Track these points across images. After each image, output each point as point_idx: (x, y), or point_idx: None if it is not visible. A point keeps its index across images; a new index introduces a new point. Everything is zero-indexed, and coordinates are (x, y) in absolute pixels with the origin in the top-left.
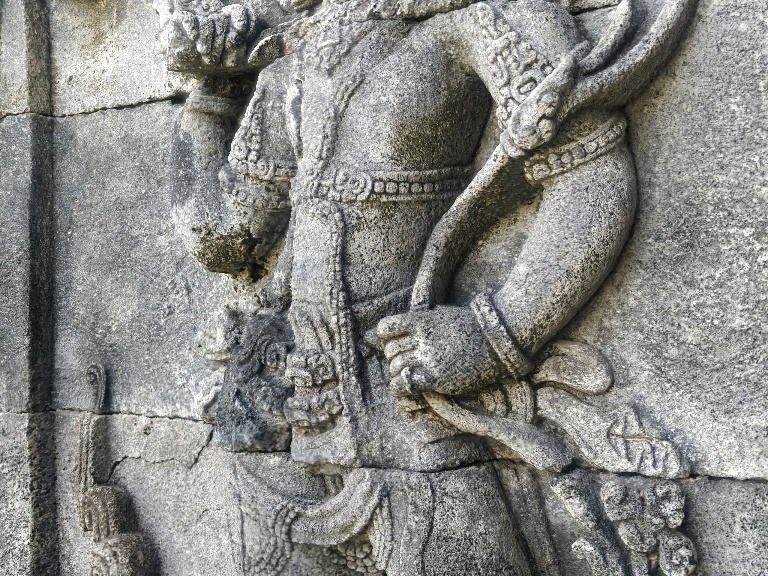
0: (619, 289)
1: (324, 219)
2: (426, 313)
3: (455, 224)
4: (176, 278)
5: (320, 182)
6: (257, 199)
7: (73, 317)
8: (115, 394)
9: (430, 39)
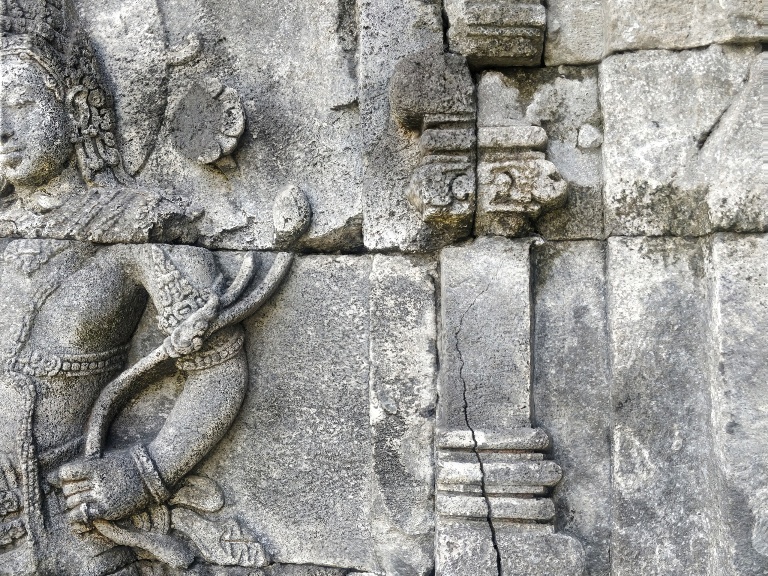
0: (232, 441)
1: (20, 389)
2: (100, 463)
3: (119, 392)
4: None
5: (17, 360)
6: None
7: None
8: None
9: (113, 261)
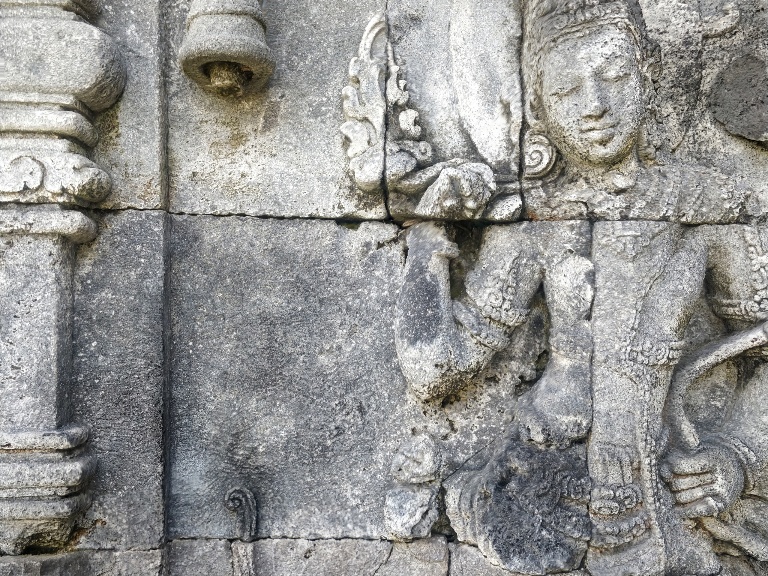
0: None
1: (638, 379)
2: (715, 455)
3: None
4: (347, 399)
5: (632, 348)
6: (500, 342)
7: (200, 437)
8: (264, 519)
9: (702, 243)
